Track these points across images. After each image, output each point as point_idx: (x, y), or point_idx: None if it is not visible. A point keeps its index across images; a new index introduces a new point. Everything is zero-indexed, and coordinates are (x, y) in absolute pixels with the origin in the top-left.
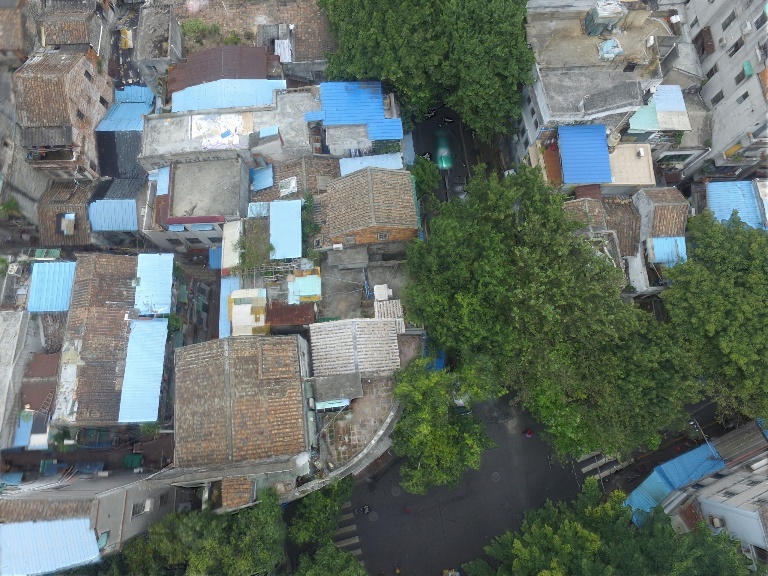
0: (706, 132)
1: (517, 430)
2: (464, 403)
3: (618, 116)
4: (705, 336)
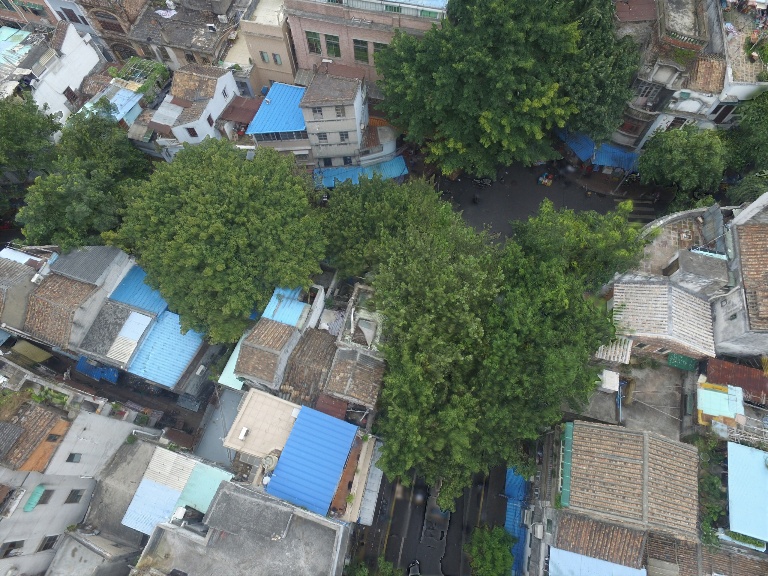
0: (122, 456)
1: None
2: None
3: None
4: None
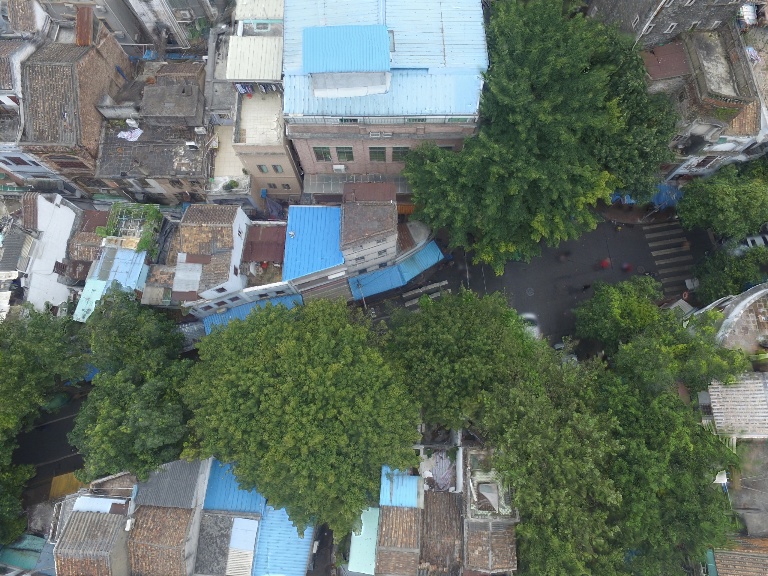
0: None
1: None
2: None
3: None
4: None
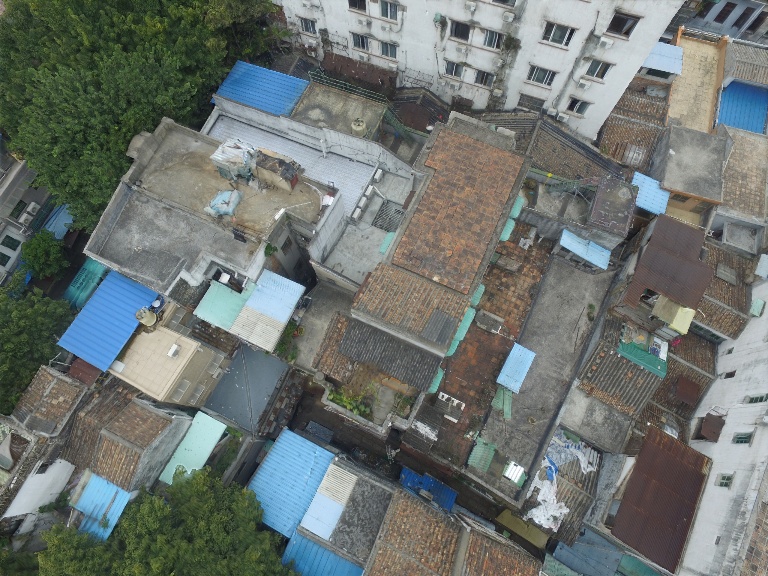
0: None
1: None
2: None
3: None
4: None
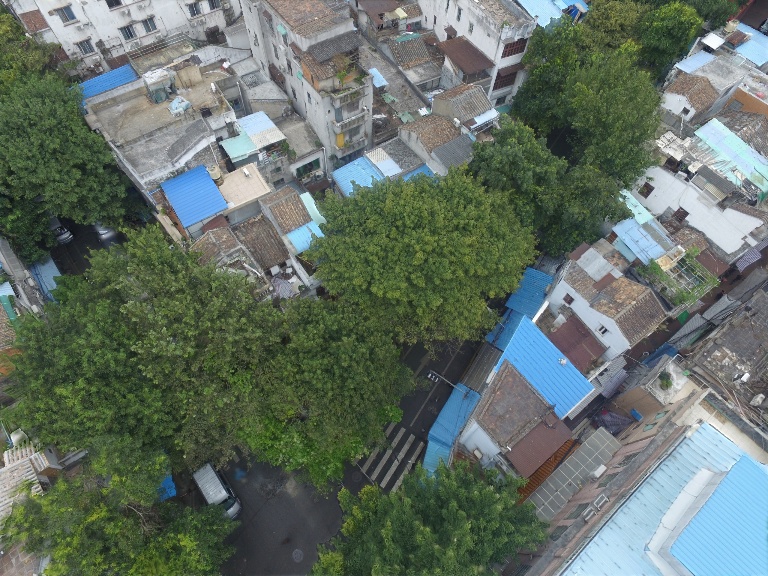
0: (313, 137)
1: (298, 489)
2: (139, 502)
3: (205, 152)
4: (370, 292)
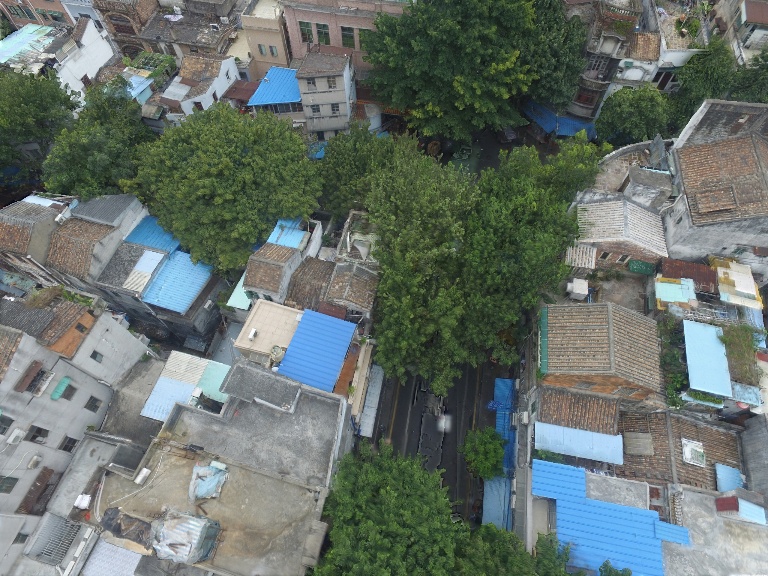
0: (137, 371)
1: None
2: None
3: None
4: None
